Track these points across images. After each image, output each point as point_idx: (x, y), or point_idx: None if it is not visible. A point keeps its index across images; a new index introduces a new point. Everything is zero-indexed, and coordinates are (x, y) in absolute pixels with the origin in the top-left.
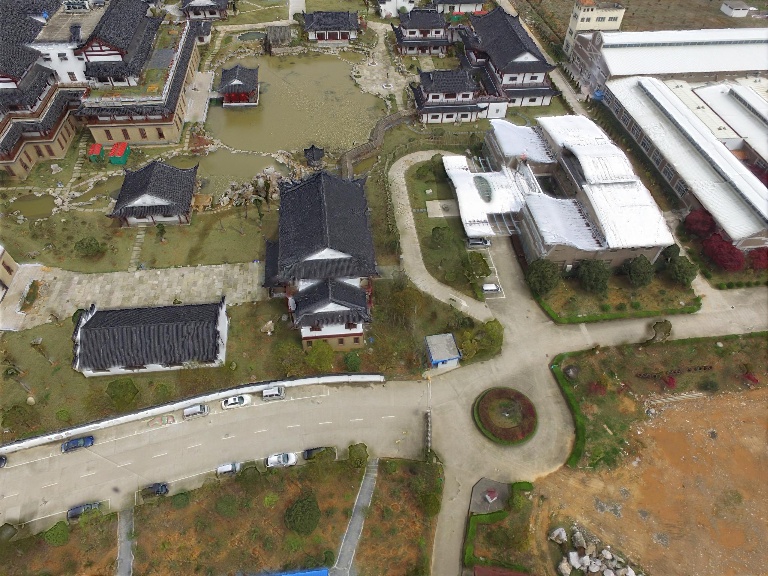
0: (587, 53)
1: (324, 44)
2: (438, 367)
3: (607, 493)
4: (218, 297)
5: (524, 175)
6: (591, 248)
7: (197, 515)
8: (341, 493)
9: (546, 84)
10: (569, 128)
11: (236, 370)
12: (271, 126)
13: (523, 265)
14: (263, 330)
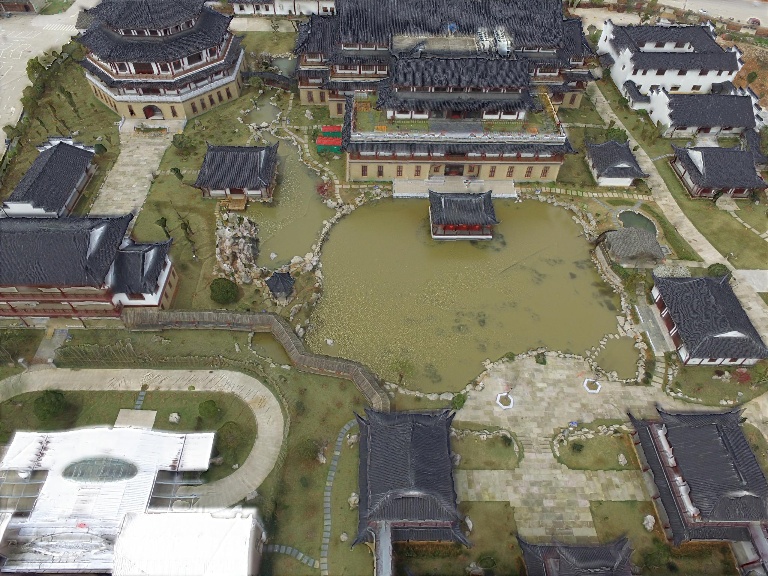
0: None
1: (652, 315)
2: None
3: None
4: None
5: (94, 554)
6: None
7: None
8: None
9: None
10: None
11: None
12: None
13: None
14: None
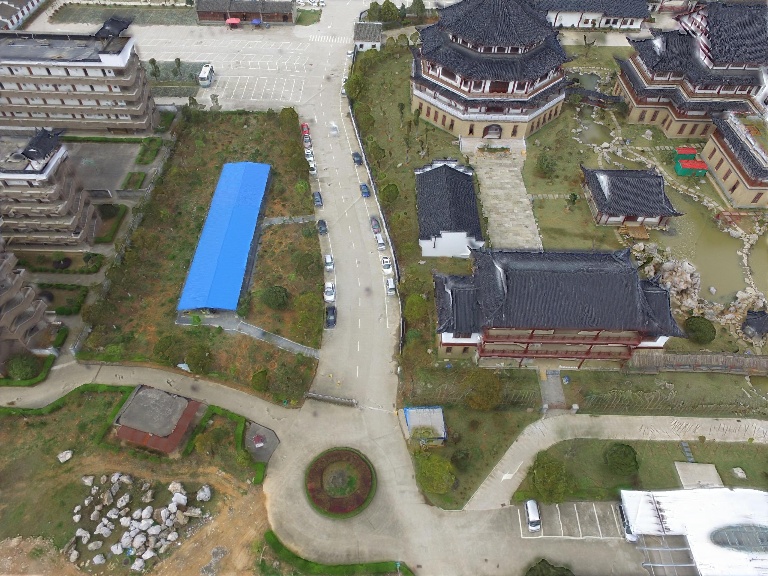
0: None
1: None
2: None
3: (229, 568)
4: (501, 250)
5: None
6: None
7: (301, 250)
8: (294, 329)
9: None
10: None
11: (418, 264)
12: None
13: None
14: None
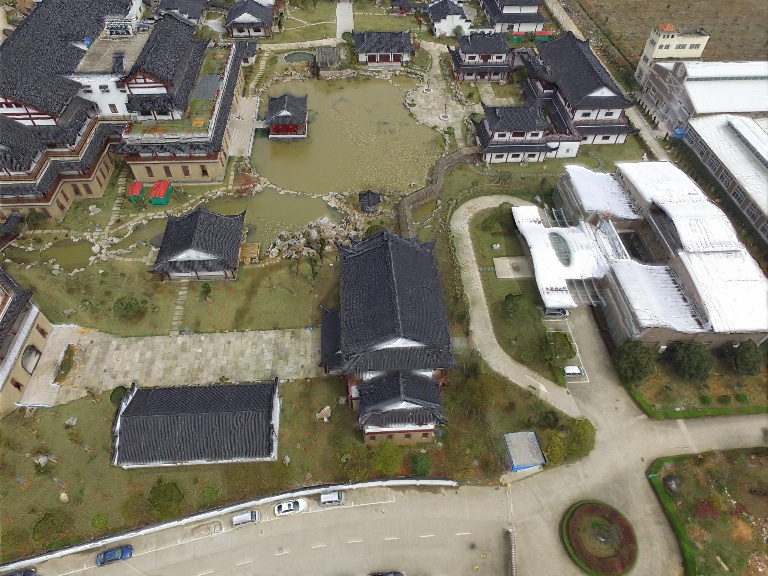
0: (666, 85)
1: (375, 67)
2: (518, 470)
3: None
4: (268, 371)
5: (606, 233)
6: (691, 330)
7: None
8: None
9: (622, 121)
10: (656, 179)
11: (290, 466)
12: (320, 161)
13: (608, 342)
14: (319, 416)
